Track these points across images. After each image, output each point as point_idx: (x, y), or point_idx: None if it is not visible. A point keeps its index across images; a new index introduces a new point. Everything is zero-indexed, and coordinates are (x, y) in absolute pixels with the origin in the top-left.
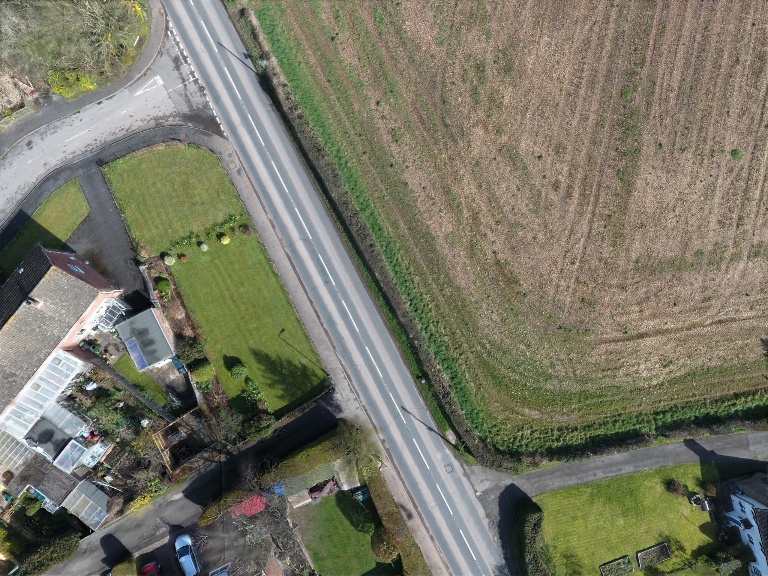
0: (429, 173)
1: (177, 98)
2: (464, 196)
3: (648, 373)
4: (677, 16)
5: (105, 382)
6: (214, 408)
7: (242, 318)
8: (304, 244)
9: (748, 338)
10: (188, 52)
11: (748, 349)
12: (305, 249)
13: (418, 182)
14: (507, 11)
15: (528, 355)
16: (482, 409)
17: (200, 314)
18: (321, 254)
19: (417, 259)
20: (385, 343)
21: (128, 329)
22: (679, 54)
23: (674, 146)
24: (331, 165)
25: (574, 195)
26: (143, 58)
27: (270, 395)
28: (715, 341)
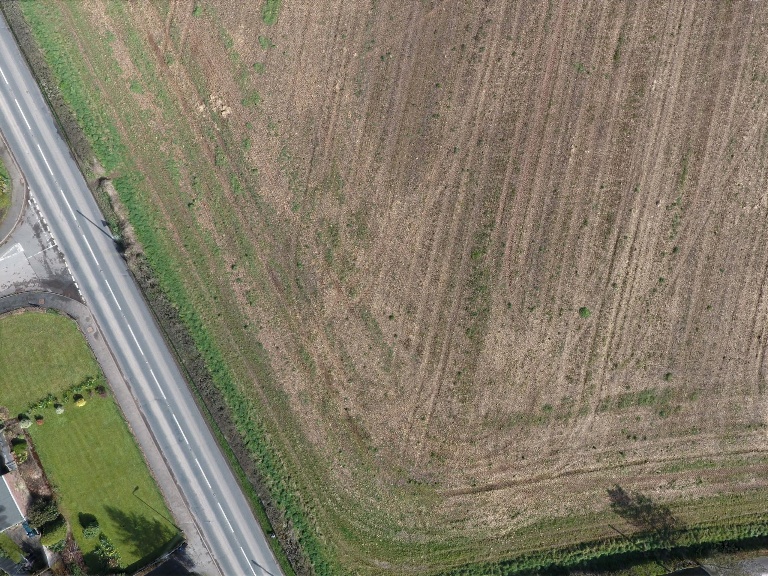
0: (283, 333)
1: (37, 265)
2: (317, 355)
3: (496, 524)
4: (526, 180)
5: None
6: (69, 564)
7: (97, 477)
8: (159, 404)
9: (595, 489)
10: (48, 220)
11: (595, 500)
12: (160, 409)
13: (272, 342)
14: (360, 176)
15: (378, 508)
16: (332, 561)
17: (56, 473)
18: (175, 414)
19: (270, 416)
20: (237, 499)
21: None
22: (528, 216)
23: (523, 305)
24: (182, 332)
25: (424, 353)
26: (3, 227)
27: (124, 551)
28: (563, 492)
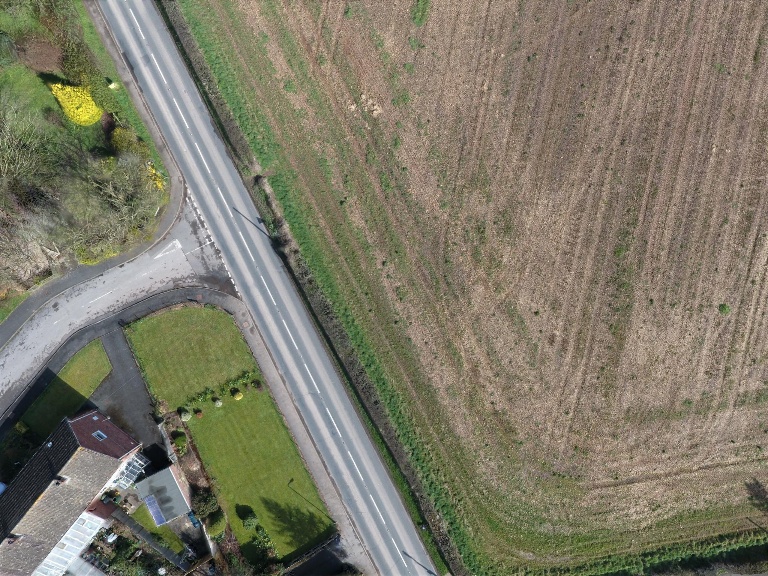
0: (431, 329)
1: (194, 261)
2: (464, 350)
3: (637, 516)
4: (669, 178)
5: (125, 531)
6: (227, 554)
7: (254, 469)
8: (313, 398)
9: (733, 483)
10: (205, 217)
11: (733, 493)
12: (313, 403)
13: (421, 337)
14: (507, 174)
15: (523, 500)
16: (479, 552)
17: (214, 465)
18: (328, 407)
19: (419, 410)
20: (388, 491)
21: (147, 487)
22: (670, 214)
23: (664, 302)
24: (339, 327)
25: (569, 349)
26: (163, 224)
27: (279, 541)
28: (702, 485)
